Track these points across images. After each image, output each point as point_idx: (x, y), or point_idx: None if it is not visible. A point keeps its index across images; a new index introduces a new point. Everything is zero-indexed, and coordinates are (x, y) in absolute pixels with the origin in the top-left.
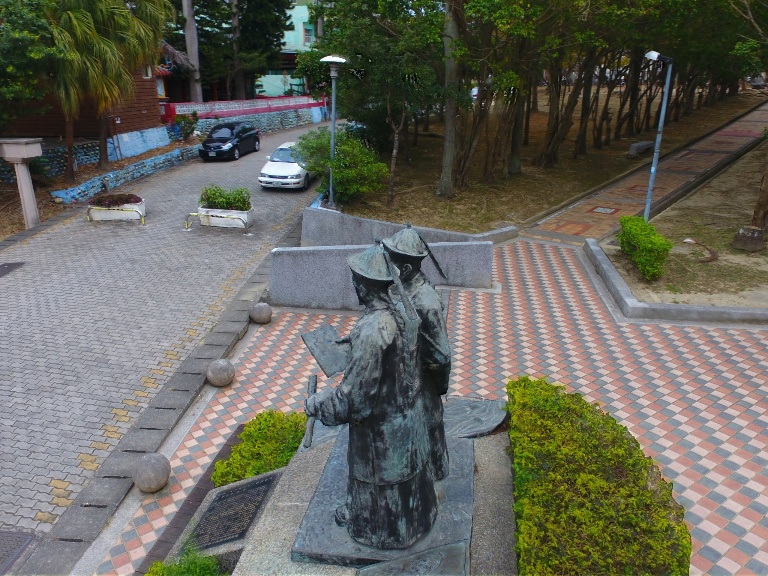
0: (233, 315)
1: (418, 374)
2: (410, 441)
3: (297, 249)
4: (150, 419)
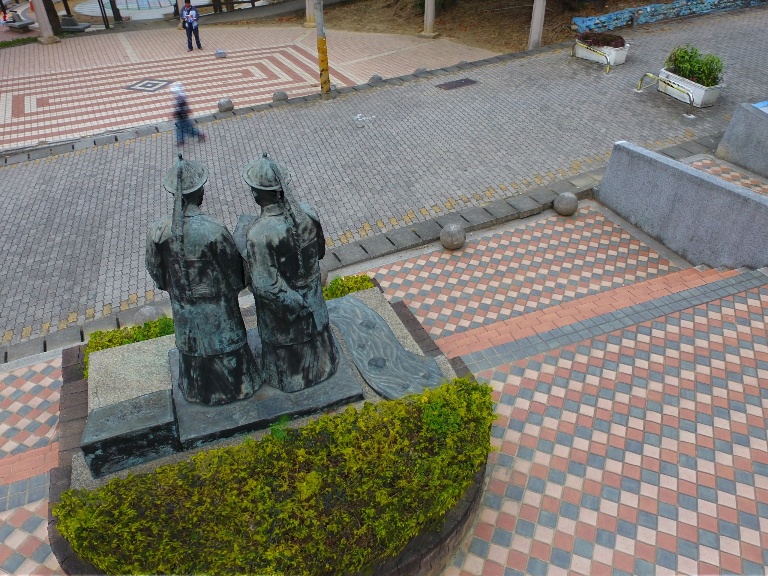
0: (542, 193)
1: (210, 284)
2: (188, 328)
3: (638, 150)
4: (373, 242)
